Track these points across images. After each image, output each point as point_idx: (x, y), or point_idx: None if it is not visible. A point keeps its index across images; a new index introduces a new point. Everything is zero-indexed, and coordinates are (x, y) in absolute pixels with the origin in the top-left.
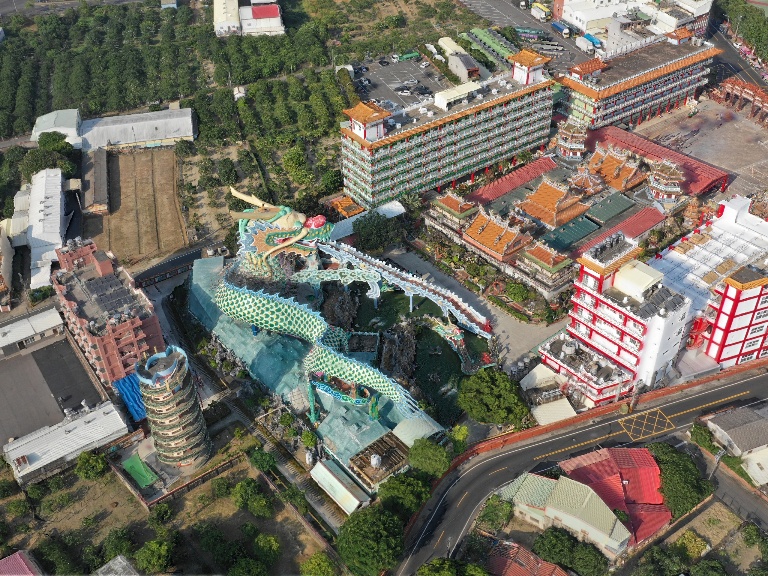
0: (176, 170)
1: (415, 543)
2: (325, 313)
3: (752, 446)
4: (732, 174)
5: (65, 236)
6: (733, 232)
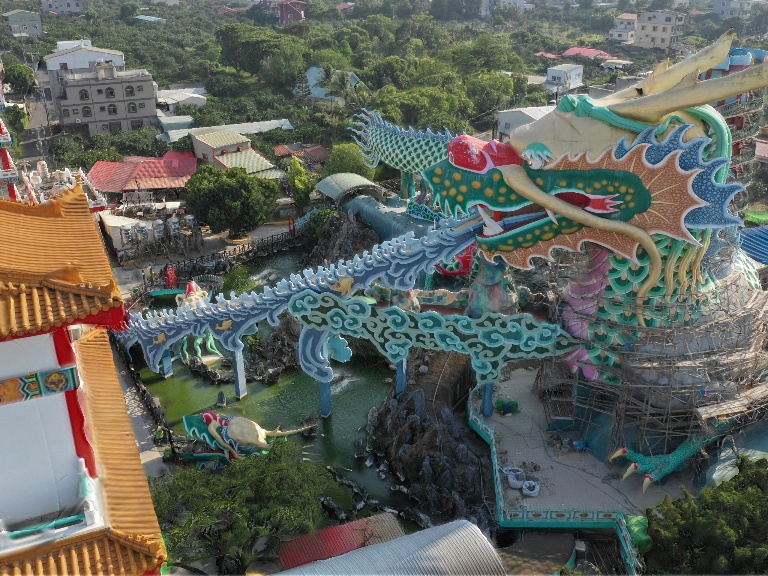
0: None
1: None
2: None
3: None
4: None
5: None
6: None
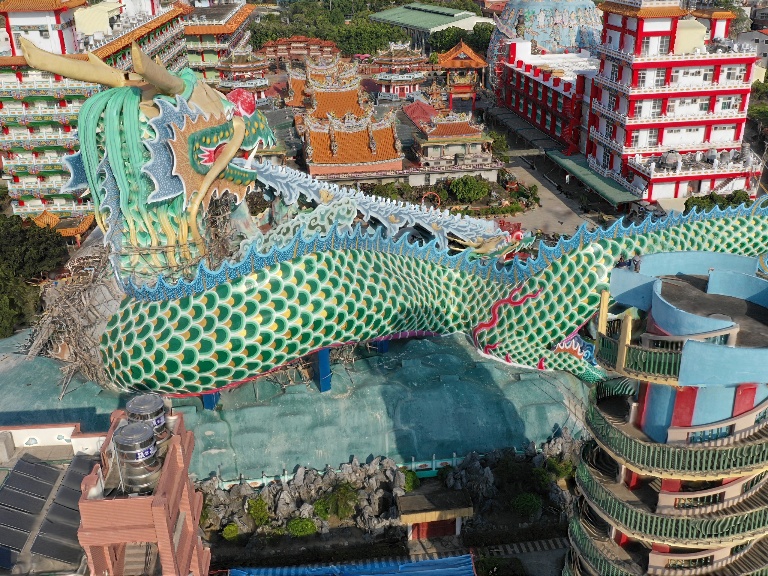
0: None
1: None
2: None
3: None
4: None
5: None
6: None
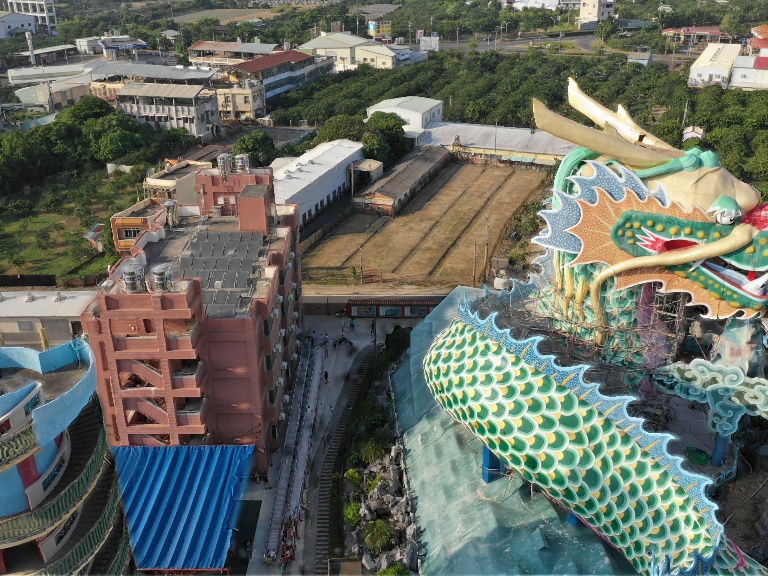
0: (535, 190)
1: None
2: (726, 507)
3: None
4: None
5: (306, 222)
6: None
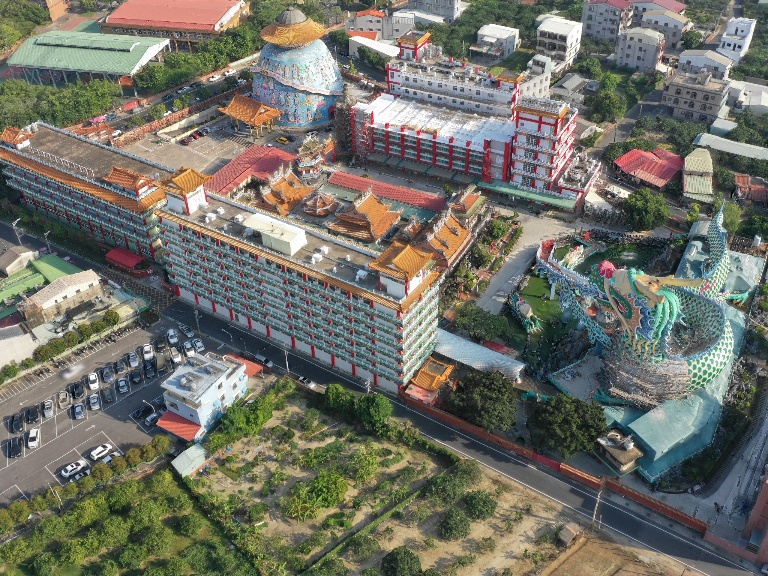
0: None
1: None
2: None
3: (590, 122)
4: (220, 161)
5: None
6: (391, 118)
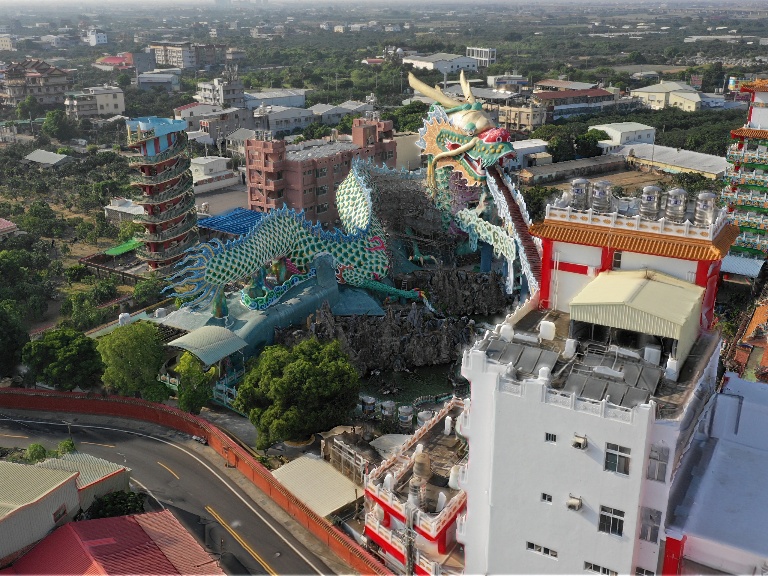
0: None
1: (7, 417)
2: None
3: None
4: None
5: None
6: None
